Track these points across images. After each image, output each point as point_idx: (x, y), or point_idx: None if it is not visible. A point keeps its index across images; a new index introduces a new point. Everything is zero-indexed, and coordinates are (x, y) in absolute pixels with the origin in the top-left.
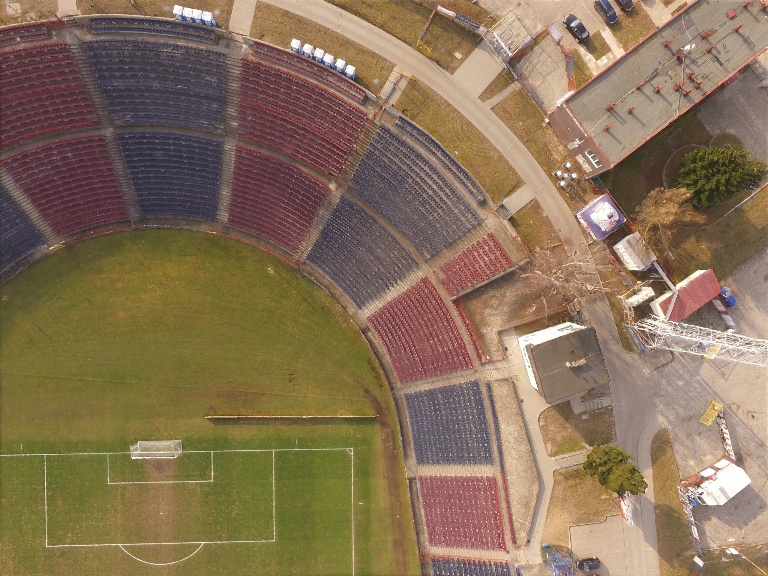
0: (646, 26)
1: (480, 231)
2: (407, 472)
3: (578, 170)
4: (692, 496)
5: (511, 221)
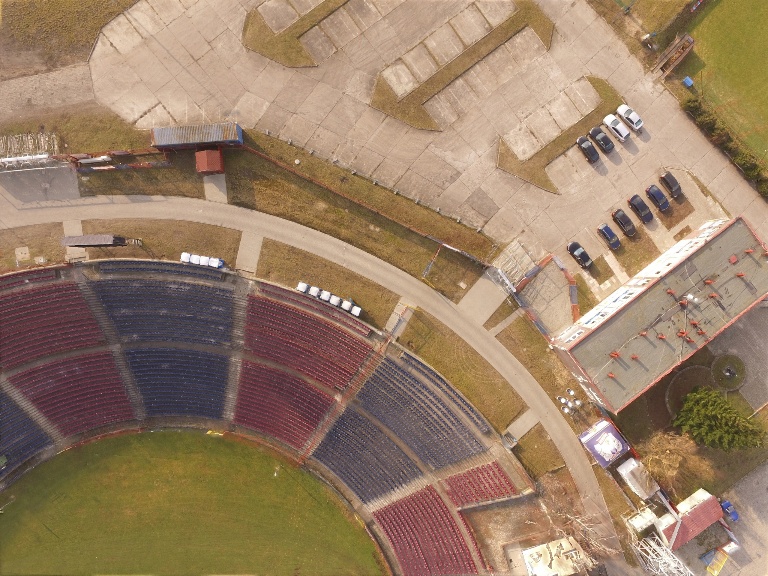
0: (649, 250)
1: (485, 457)
2: None
3: (582, 394)
4: None
5: (516, 447)
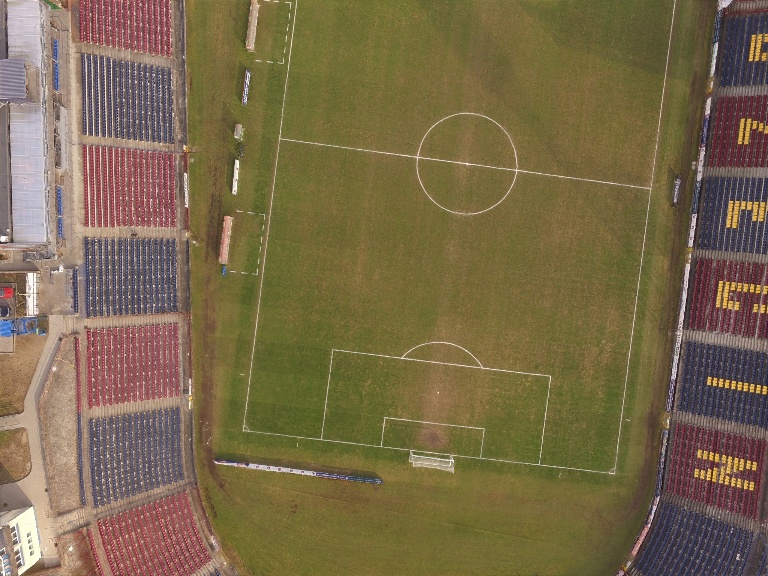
0: None
1: None
2: None
3: None
4: None
5: None
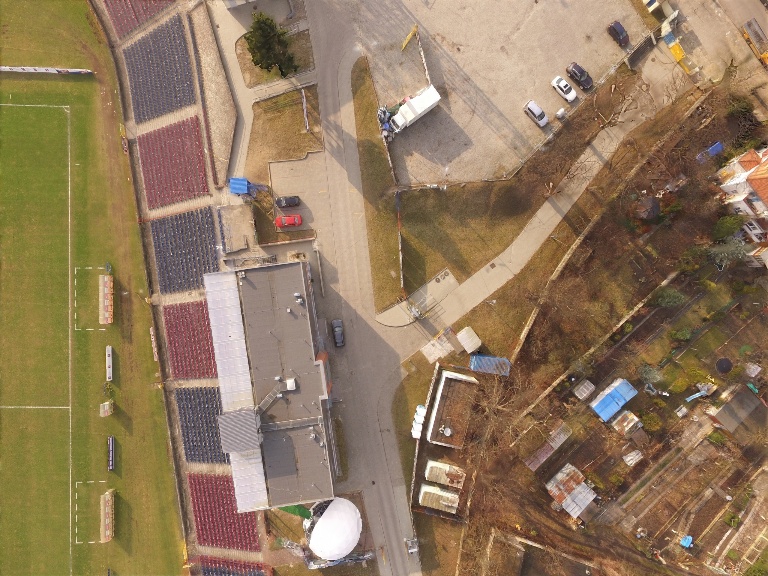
0: None
1: None
2: (127, 133)
3: None
4: (381, 114)
5: None
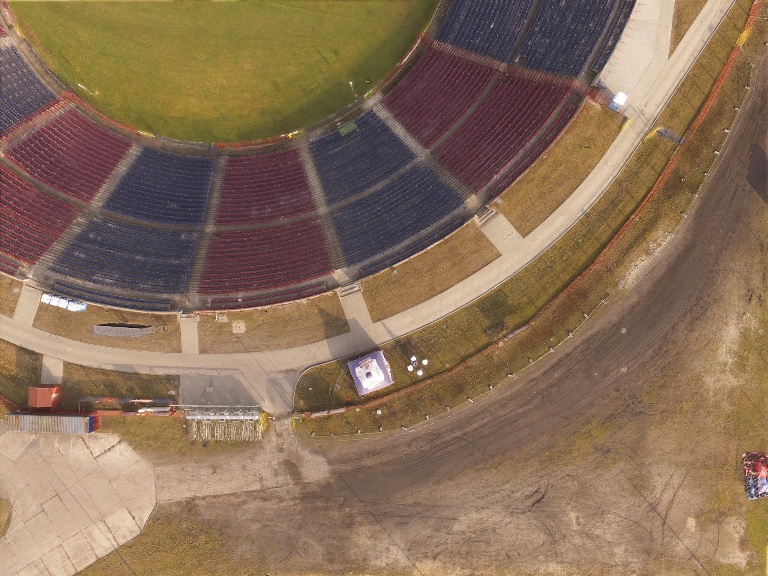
0: None
1: None
2: None
3: None
4: None
5: None
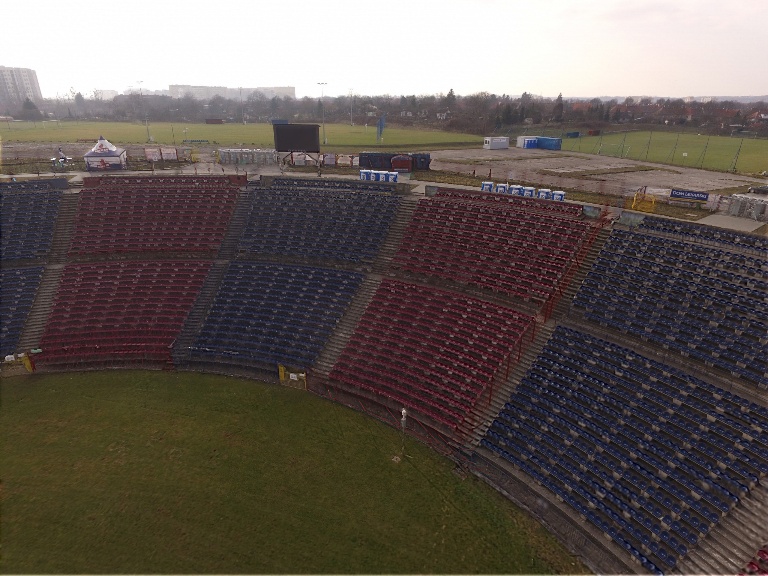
0: None
1: None
2: None
3: None
4: None
5: None
